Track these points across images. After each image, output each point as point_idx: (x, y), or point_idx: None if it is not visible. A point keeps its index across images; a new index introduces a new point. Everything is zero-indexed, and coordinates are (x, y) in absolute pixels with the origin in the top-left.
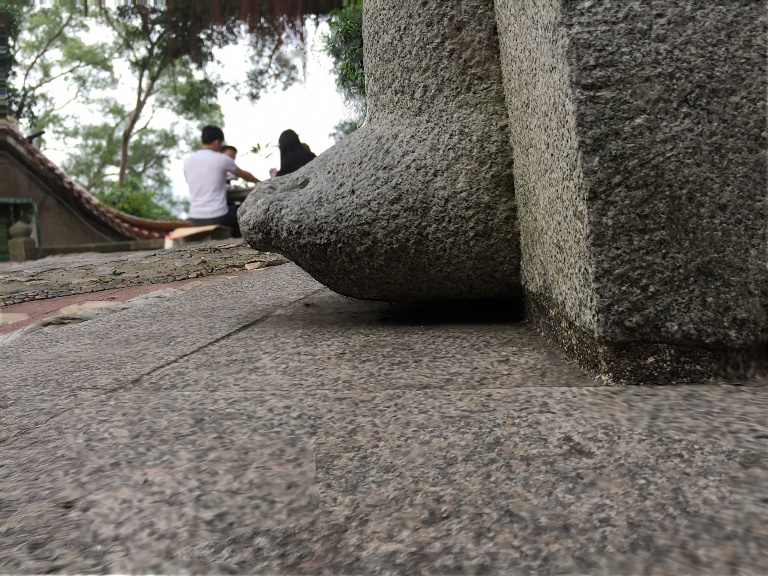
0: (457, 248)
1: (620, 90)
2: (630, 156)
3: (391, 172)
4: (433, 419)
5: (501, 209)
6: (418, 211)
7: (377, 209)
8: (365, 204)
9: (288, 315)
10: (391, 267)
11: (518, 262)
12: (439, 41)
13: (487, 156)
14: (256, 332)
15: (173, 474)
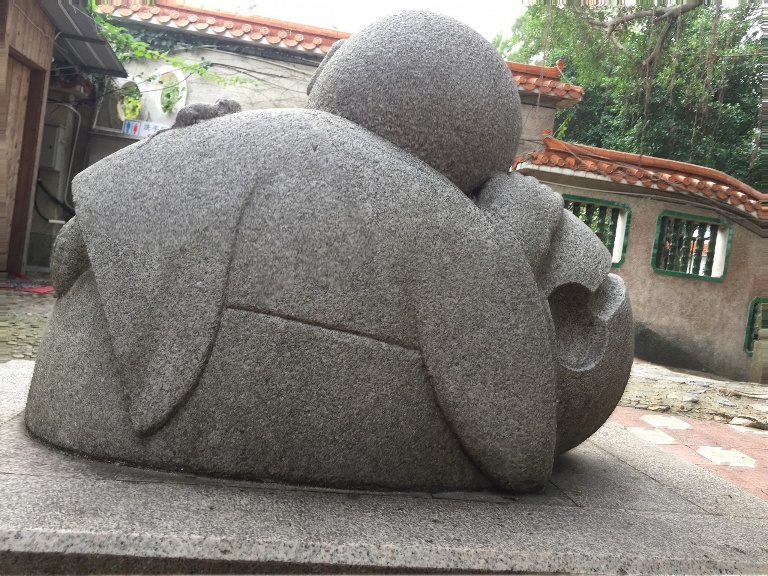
0: None
1: None
2: None
3: None
4: None
5: None
6: None
7: None
8: None
9: None
10: None
11: None
12: None
13: None
14: None
15: None
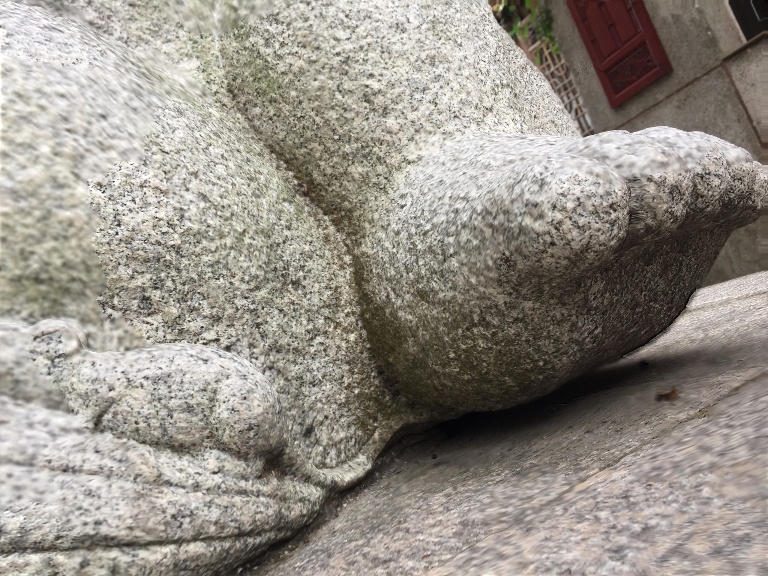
0: None
1: None
2: None
3: None
4: None
5: None
6: None
7: None
8: None
9: None
10: None
11: None
12: None
13: None
14: None
15: None
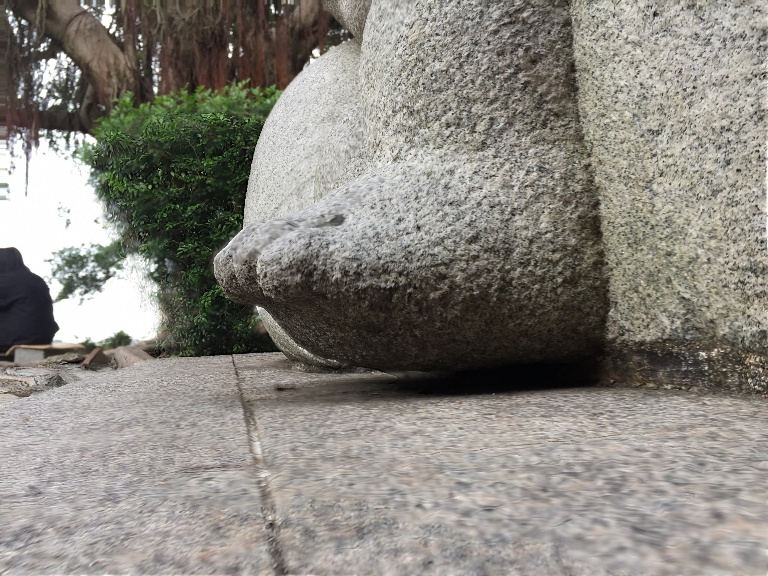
0: (543, 296)
1: None
2: None
3: (460, 208)
4: None
5: (588, 253)
6: (500, 252)
7: (453, 248)
8: (438, 242)
9: (274, 398)
10: (466, 319)
11: (604, 313)
12: (512, 72)
13: (572, 195)
14: (283, 411)
15: None
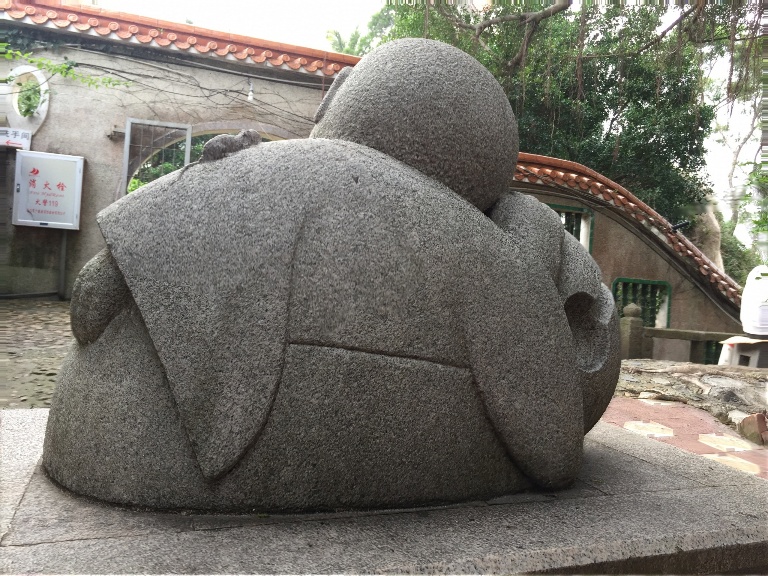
0: None
1: None
2: None
3: None
4: None
5: None
6: None
7: None
8: None
9: None
10: None
11: None
12: None
13: None
14: None
15: None
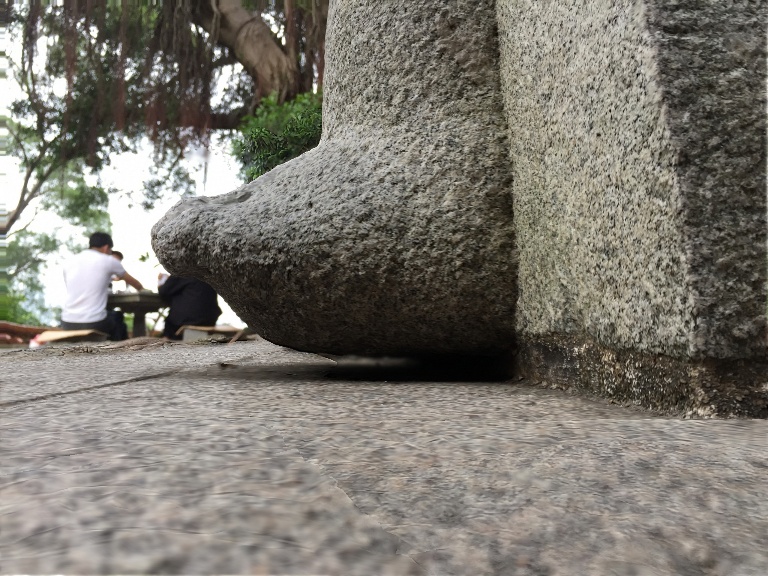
0: (439, 280)
1: (710, 36)
2: (728, 114)
3: (360, 185)
4: (503, 444)
5: (496, 235)
6: (393, 231)
7: (341, 226)
8: (326, 219)
9: (201, 372)
10: (353, 301)
11: (513, 302)
12: (428, 39)
13: (481, 171)
14: (162, 380)
15: (33, 501)
